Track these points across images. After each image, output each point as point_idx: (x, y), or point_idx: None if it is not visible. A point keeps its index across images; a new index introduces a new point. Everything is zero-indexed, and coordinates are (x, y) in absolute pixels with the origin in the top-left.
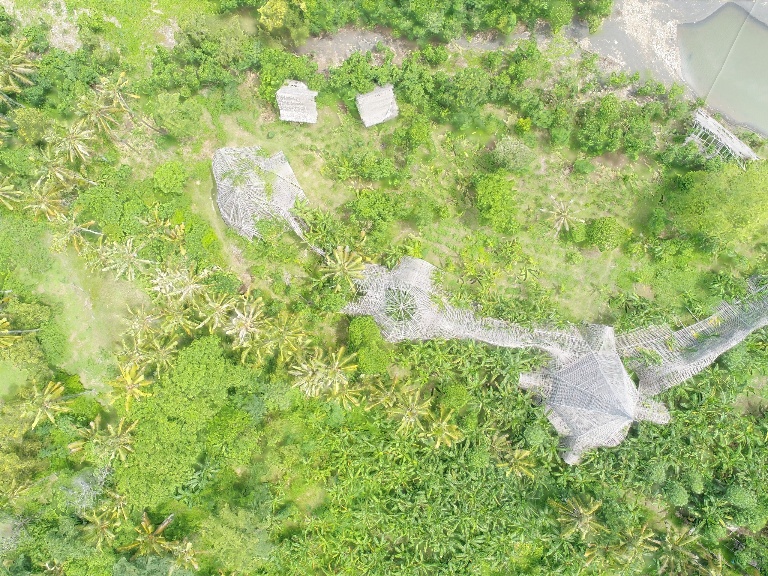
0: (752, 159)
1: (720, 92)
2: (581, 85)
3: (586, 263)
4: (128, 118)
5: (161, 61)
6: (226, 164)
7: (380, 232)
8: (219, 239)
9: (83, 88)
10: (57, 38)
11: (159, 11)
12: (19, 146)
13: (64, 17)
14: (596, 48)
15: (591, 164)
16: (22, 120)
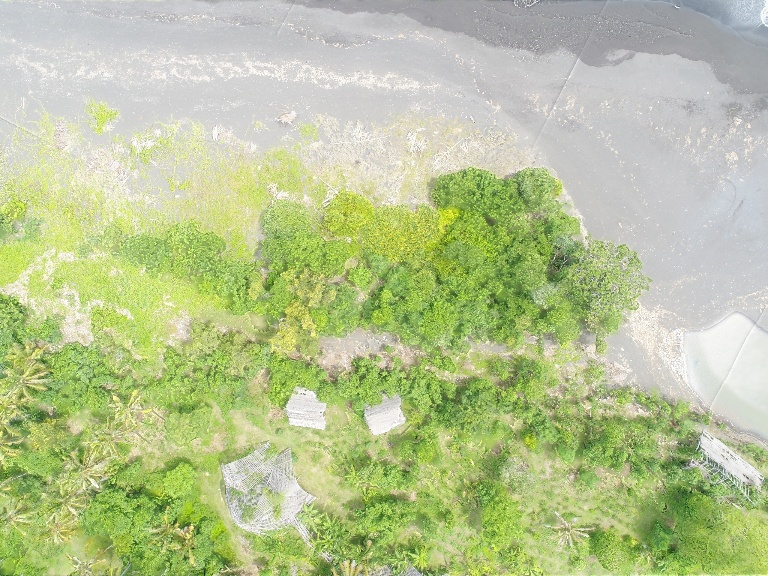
0: (756, 488)
1: (725, 399)
2: (587, 392)
3: (589, 566)
4: (139, 408)
5: (172, 365)
6: (235, 483)
7: (386, 539)
8: (227, 529)
9: (96, 399)
10: (70, 328)
11: (171, 304)
12: (32, 446)
13: (77, 308)
14: (603, 355)
15: (596, 471)
16: (36, 436)
